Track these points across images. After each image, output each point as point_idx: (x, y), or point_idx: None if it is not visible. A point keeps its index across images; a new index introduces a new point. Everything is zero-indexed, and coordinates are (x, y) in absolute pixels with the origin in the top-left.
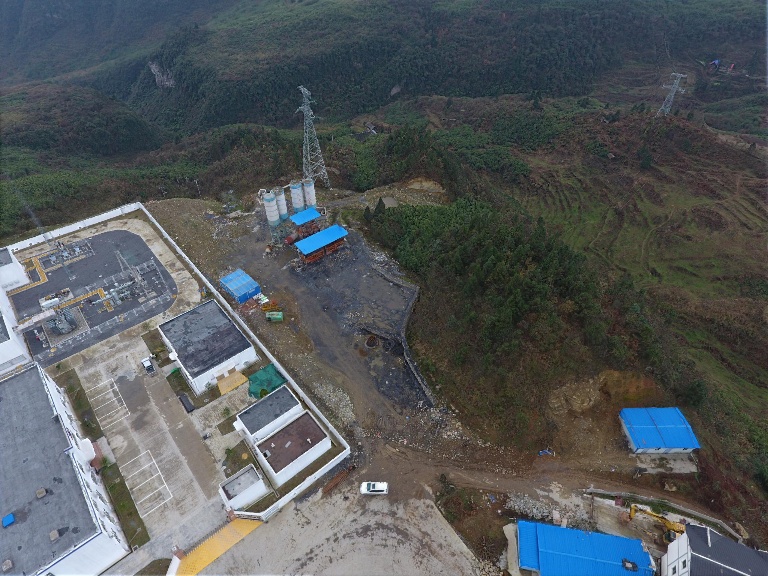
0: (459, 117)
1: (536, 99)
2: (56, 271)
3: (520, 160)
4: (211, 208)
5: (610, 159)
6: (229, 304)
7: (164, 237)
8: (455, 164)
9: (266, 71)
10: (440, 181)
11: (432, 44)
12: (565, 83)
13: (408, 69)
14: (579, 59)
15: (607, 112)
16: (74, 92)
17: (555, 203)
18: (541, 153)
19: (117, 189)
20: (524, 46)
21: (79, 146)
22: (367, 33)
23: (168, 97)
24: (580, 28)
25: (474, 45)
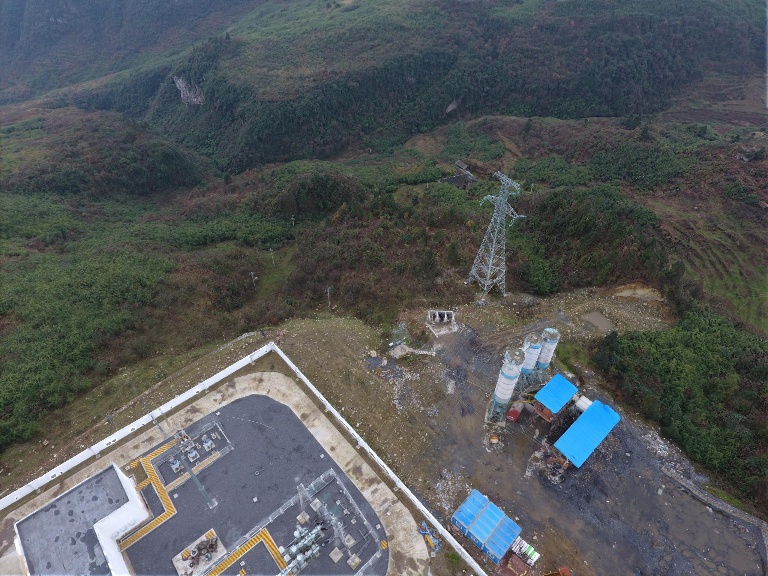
0: (543, 145)
1: (646, 128)
2: (183, 488)
3: (643, 205)
4: (368, 343)
5: (763, 209)
6: (478, 563)
7: (326, 409)
8: (682, 265)
9: (313, 89)
10: (660, 287)
11: (493, 55)
12: (642, 98)
13: (467, 84)
14: (658, 71)
15: (745, 148)
16: (101, 120)
17: (706, 266)
18: (662, 195)
19: (201, 282)
20: (599, 58)
21: (112, 186)
22: (421, 44)
23: (196, 116)
24: (659, 37)
25: (540, 56)
